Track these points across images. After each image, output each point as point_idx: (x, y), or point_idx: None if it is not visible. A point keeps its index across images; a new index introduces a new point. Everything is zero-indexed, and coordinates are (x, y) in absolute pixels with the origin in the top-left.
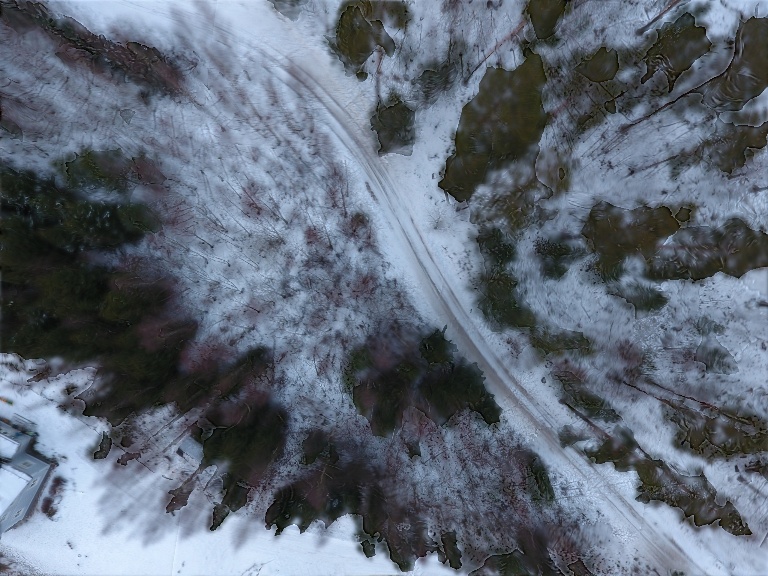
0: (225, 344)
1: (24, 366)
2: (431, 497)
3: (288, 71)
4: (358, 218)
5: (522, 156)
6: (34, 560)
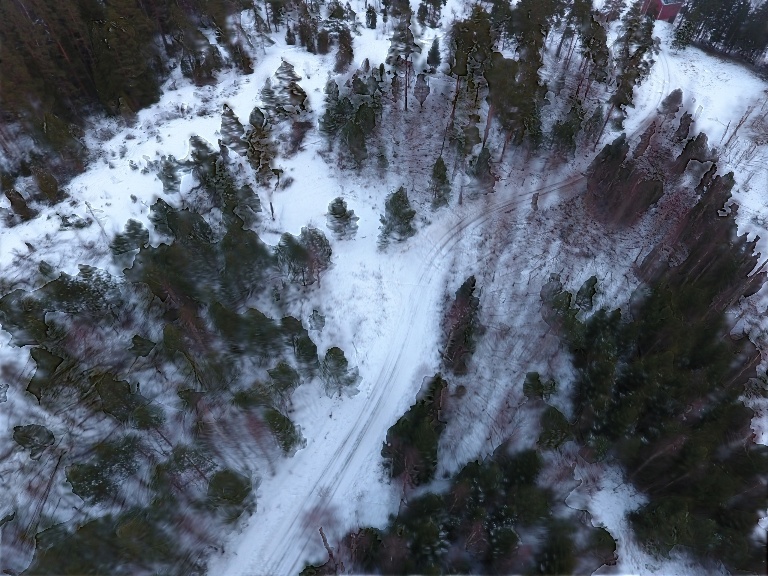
0: None
1: None
2: (680, 206)
3: (443, 246)
4: (537, 198)
5: None
6: None
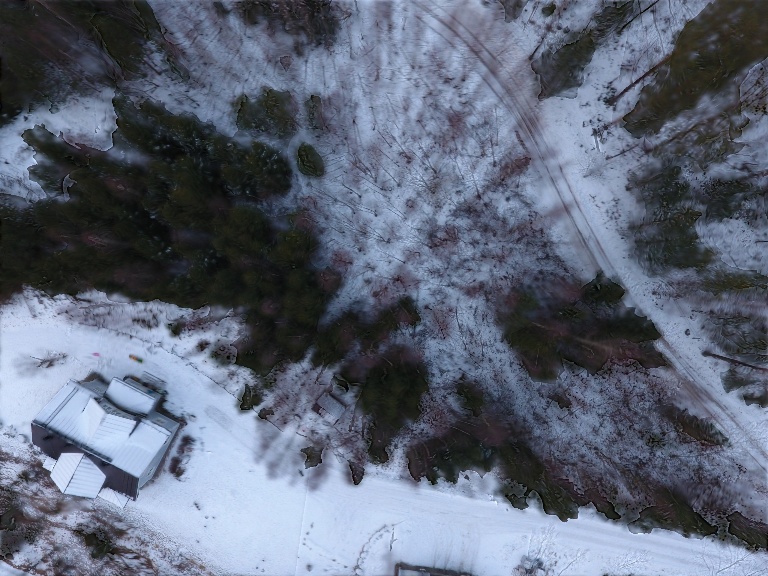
0: (368, 296)
1: (157, 322)
2: (567, 454)
3: (441, 20)
4: (520, 161)
5: (742, 75)
6: (159, 522)
